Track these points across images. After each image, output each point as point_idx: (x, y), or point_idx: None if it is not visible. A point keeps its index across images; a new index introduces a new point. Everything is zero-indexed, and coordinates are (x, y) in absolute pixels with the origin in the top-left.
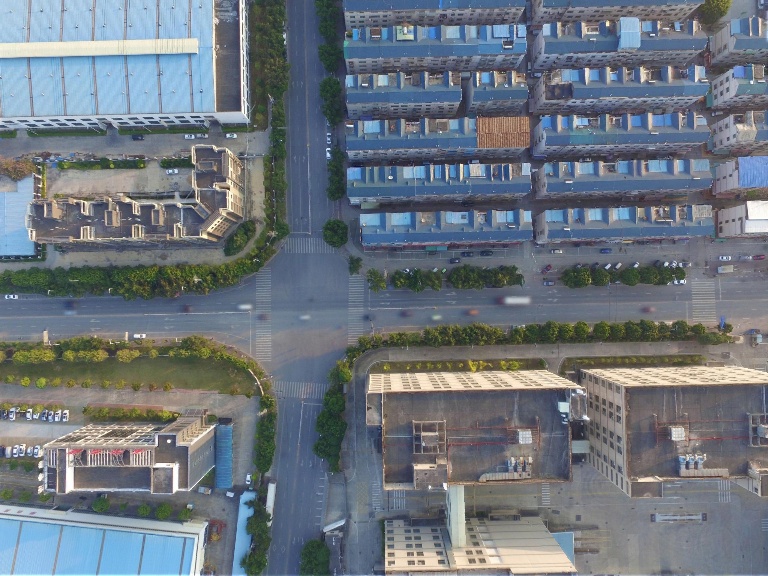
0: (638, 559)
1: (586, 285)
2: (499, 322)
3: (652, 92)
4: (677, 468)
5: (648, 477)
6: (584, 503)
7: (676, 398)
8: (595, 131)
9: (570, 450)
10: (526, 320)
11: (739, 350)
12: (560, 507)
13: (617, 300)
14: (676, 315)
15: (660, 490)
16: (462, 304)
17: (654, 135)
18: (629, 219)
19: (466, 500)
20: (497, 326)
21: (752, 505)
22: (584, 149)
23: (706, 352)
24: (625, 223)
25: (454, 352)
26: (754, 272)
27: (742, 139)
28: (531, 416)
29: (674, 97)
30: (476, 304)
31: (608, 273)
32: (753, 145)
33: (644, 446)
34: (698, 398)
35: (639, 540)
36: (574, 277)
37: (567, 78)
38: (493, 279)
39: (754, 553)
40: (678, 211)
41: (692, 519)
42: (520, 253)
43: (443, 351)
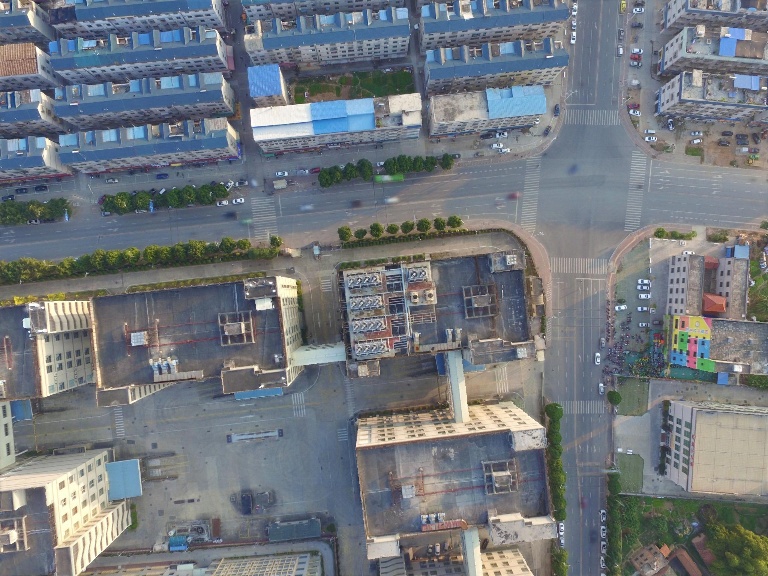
0: (217, 481)
1: (128, 210)
2: (60, 257)
3: (156, 9)
4: (153, 375)
5: (124, 386)
6: (159, 430)
7: (147, 305)
8: (100, 52)
9: (38, 366)
10: (87, 252)
11: (303, 264)
12: (135, 437)
13: (178, 225)
14: (238, 235)
15: (127, 397)
16: (21, 242)
17: (159, 51)
18: (144, 137)
19: (39, 439)
20: (57, 261)
21: (327, 416)
22: (110, 73)
23: (270, 269)
24: (138, 141)
25: (16, 291)
26: (312, 185)
27: (251, 49)
28: (2, 336)
29: (185, 13)
30: (35, 241)
31: (148, 196)
32: (282, 57)
33: (118, 356)
34: (170, 303)
35: (217, 462)
36: (110, 202)
37: (71, 1)
38: (27, 211)
39: (332, 464)
40: (194, 126)
41: (268, 436)
42: (76, 186)
43: (5, 291)
